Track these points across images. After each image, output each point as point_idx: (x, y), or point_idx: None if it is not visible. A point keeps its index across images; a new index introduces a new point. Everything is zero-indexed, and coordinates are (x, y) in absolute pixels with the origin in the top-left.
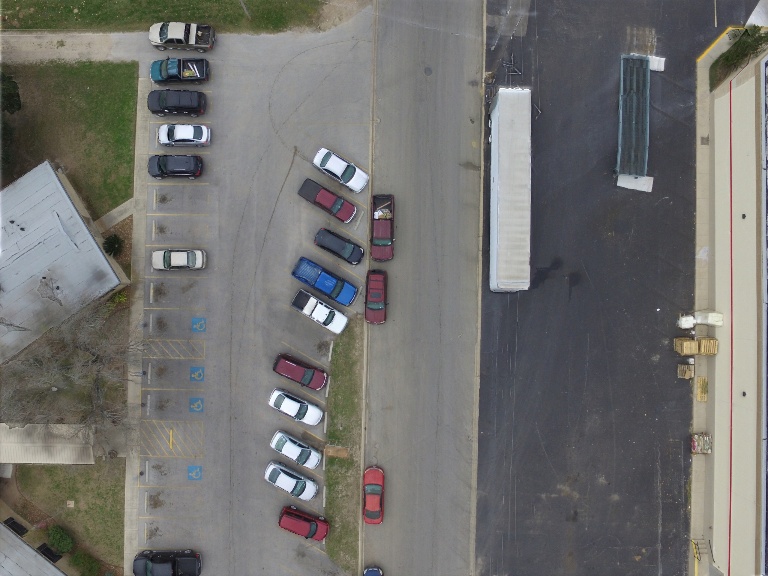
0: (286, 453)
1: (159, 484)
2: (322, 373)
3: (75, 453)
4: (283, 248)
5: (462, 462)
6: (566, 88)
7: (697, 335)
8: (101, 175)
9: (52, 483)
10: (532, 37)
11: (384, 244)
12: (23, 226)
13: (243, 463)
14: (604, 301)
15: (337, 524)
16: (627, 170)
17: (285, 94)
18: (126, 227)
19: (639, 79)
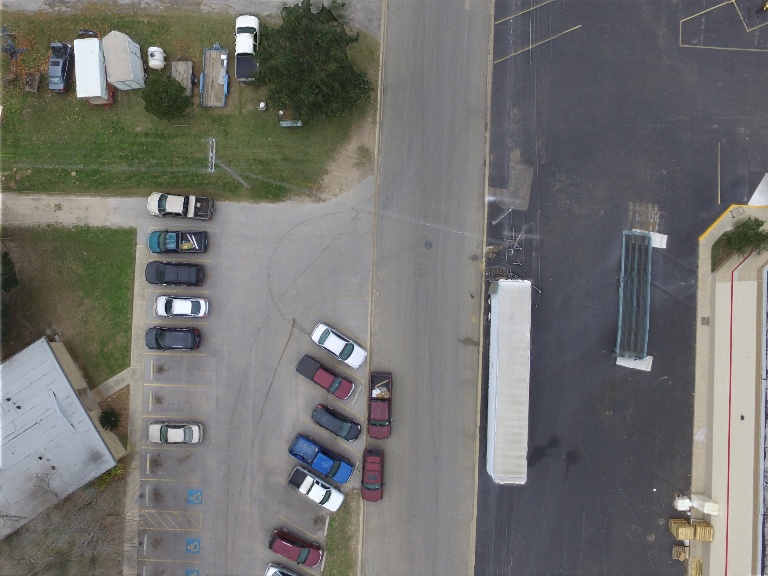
0: None
1: None
2: (318, 551)
3: None
4: (280, 421)
5: None
6: (567, 263)
7: (693, 517)
8: (98, 343)
9: None
10: (534, 211)
11: (381, 424)
12: (19, 404)
13: None
14: (601, 480)
15: None
16: (626, 353)
17: (284, 265)
18: (123, 397)
19: (641, 257)
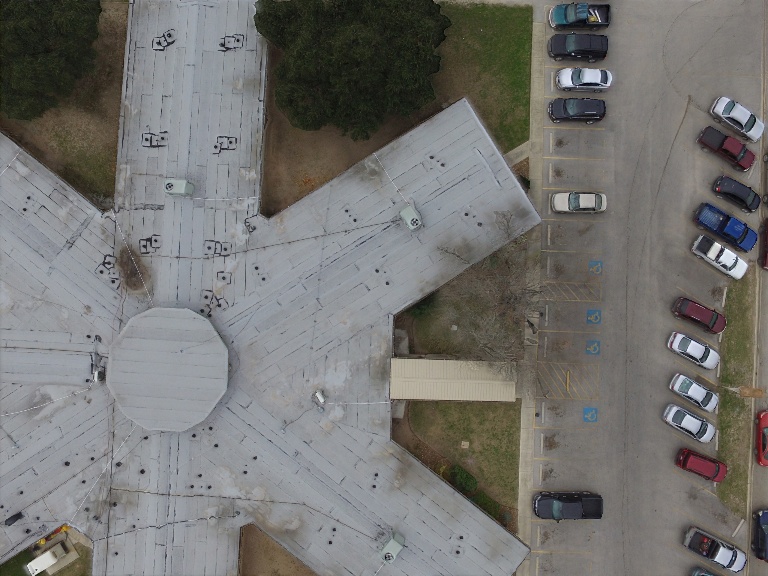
0: (693, 395)
1: (555, 426)
2: (723, 317)
3: (497, 390)
4: (678, 195)
5: None
6: None
7: None
8: (497, 117)
9: (446, 424)
10: None
11: None
12: (443, 162)
13: (638, 406)
14: None
15: (728, 467)
16: None
17: (678, 44)
18: (523, 169)
19: None
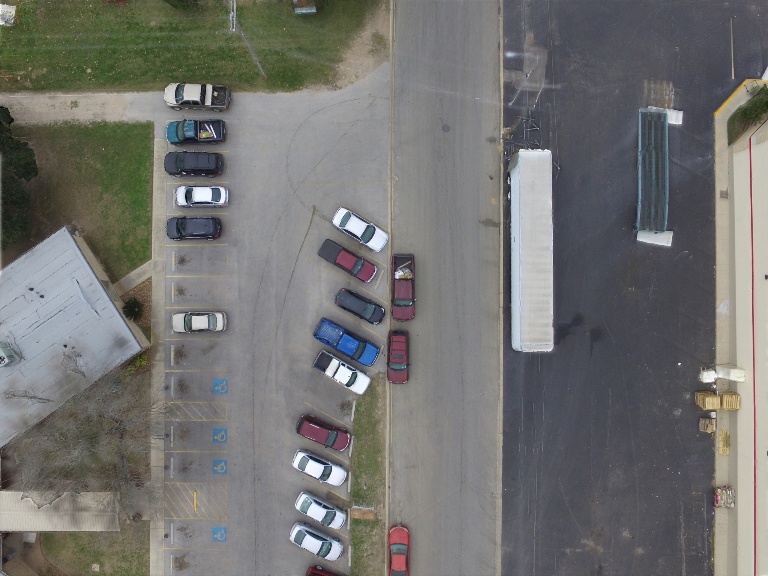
0: (311, 515)
1: (184, 546)
2: (345, 434)
3: (101, 521)
4: (303, 308)
5: (486, 519)
6: (584, 142)
7: (718, 389)
8: (119, 237)
9: (77, 547)
10: (549, 92)
11: (405, 304)
12: (43, 293)
13: (268, 524)
14: (625, 356)
15: None
16: (647, 226)
17: (302, 153)
18: (145, 289)
19: (657, 133)
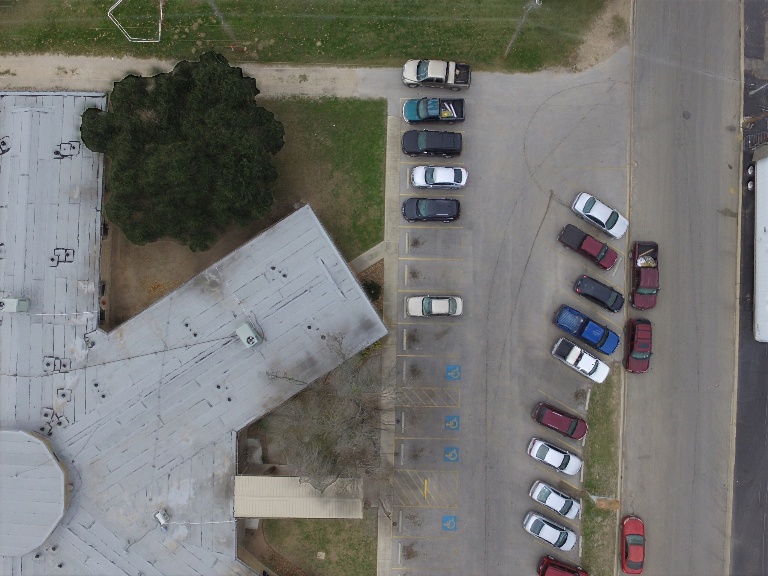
0: (551, 504)
1: (413, 535)
2: (584, 423)
3: (343, 507)
4: (539, 294)
5: (717, 510)
6: None
7: None
8: (350, 217)
9: (301, 534)
10: None
11: (649, 292)
12: (285, 272)
13: (498, 513)
14: None
15: (592, 573)
16: None
17: (540, 136)
18: (378, 271)
19: None
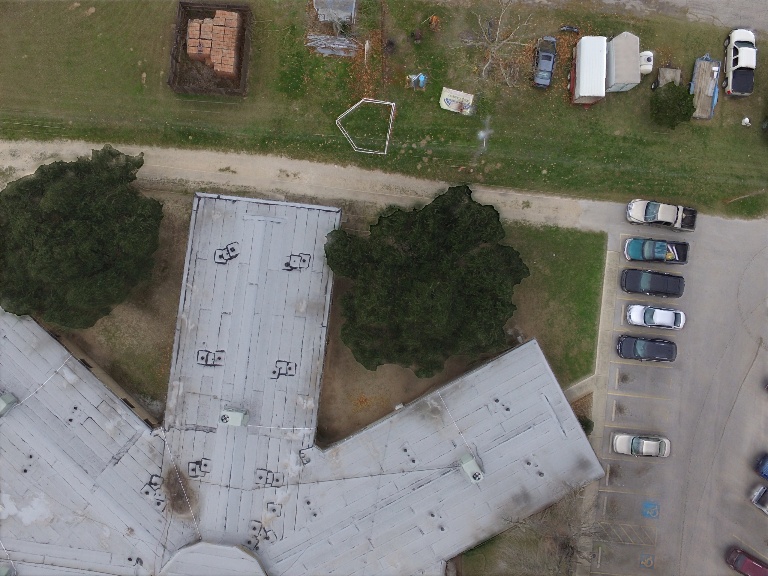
0: None
1: None
2: None
3: None
4: (742, 440)
5: None
6: None
7: None
8: (563, 348)
9: None
10: None
11: None
12: (508, 406)
13: None
14: None
15: None
16: None
17: (754, 283)
18: (587, 405)
19: None
